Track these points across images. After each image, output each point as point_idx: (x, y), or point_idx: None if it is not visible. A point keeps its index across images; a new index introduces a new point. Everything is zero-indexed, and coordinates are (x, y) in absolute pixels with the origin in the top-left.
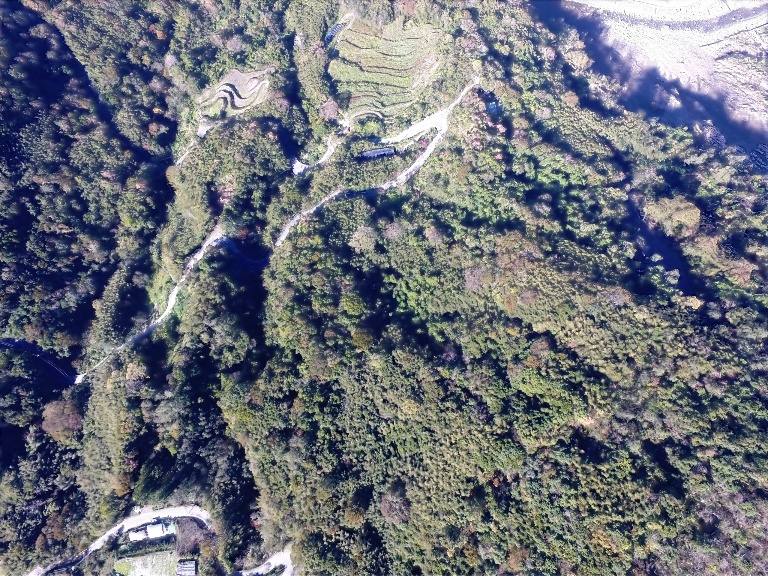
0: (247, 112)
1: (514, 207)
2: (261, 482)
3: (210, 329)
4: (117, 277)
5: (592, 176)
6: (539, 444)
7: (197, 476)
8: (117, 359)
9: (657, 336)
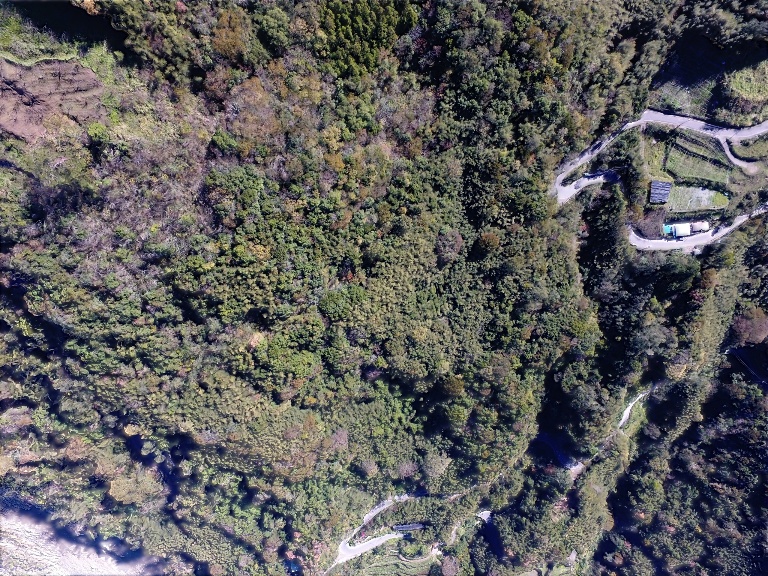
0: (529, 571)
1: (291, 496)
2: (574, 268)
3: (599, 401)
4: (674, 437)
5: (209, 514)
6: (305, 317)
7: (633, 272)
8: (689, 373)
9: (174, 406)
